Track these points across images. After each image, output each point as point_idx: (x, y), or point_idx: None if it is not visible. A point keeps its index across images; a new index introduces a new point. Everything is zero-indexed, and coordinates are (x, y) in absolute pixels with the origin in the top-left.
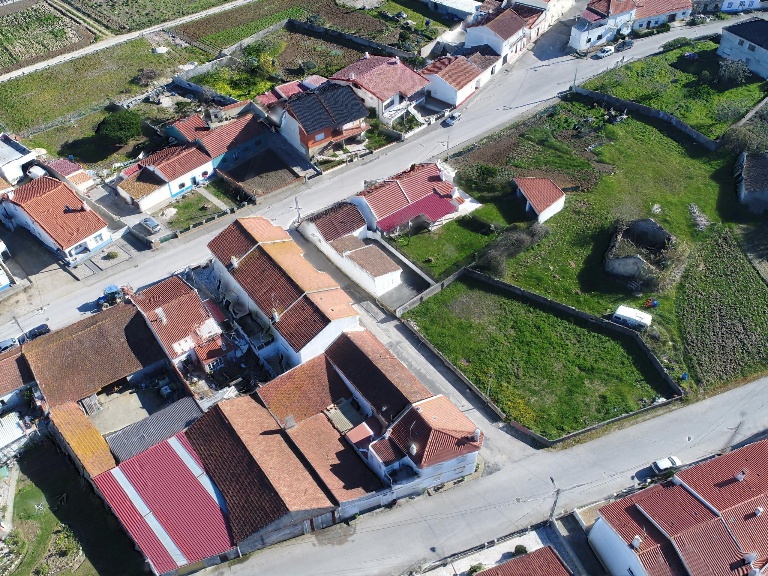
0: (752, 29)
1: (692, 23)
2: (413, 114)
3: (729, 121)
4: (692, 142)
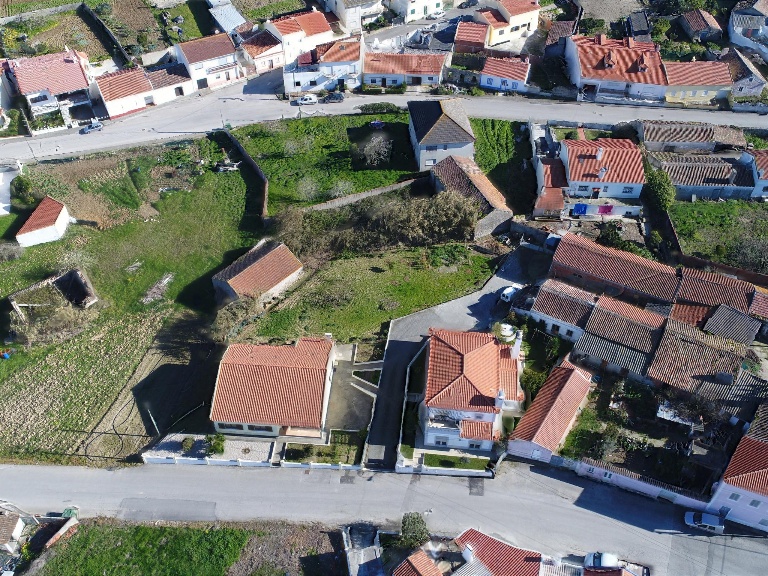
0: (424, 110)
1: (434, 91)
2: (62, 114)
3: (320, 202)
4: (258, 212)
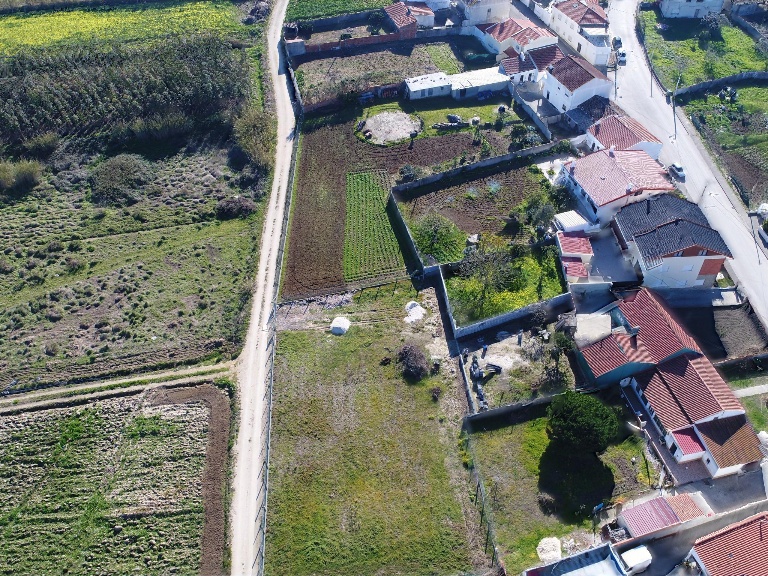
0: None
1: (605, 5)
2: None
3: (767, 56)
4: None
